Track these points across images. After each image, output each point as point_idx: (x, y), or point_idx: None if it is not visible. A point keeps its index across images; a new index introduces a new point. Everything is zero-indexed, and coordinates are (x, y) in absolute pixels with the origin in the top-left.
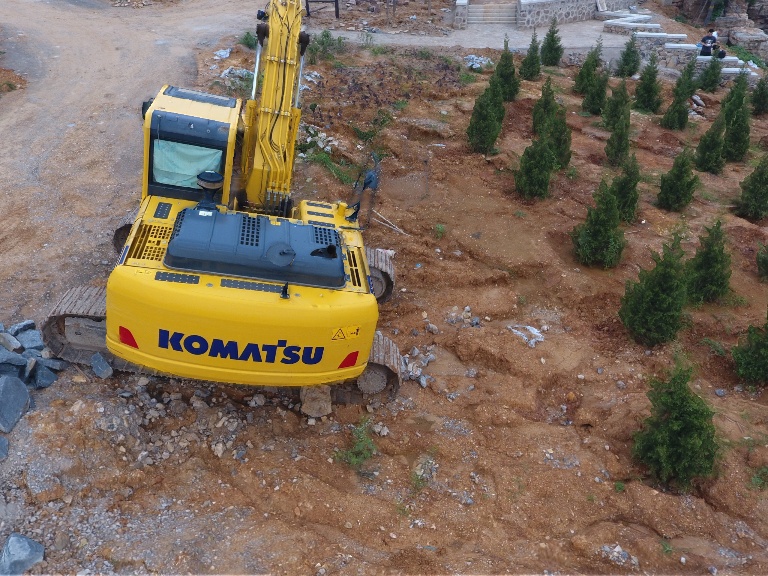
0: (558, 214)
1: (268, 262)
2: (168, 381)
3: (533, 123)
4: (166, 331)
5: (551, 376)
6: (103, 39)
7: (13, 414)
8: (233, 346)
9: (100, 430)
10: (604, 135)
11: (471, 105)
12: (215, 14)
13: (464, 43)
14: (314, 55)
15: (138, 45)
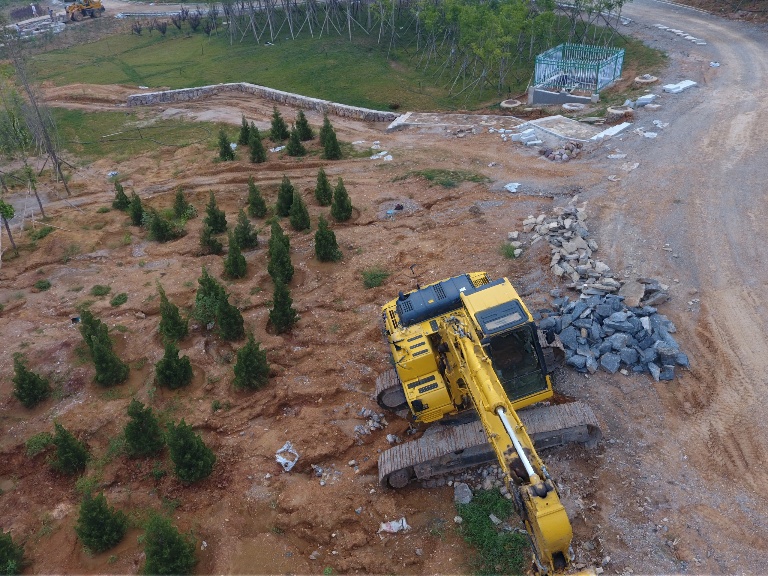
0: None
1: None
2: None
3: None
4: None
5: None
6: None
7: None
8: None
9: None
10: None
11: None
12: None
13: None
14: None
15: None
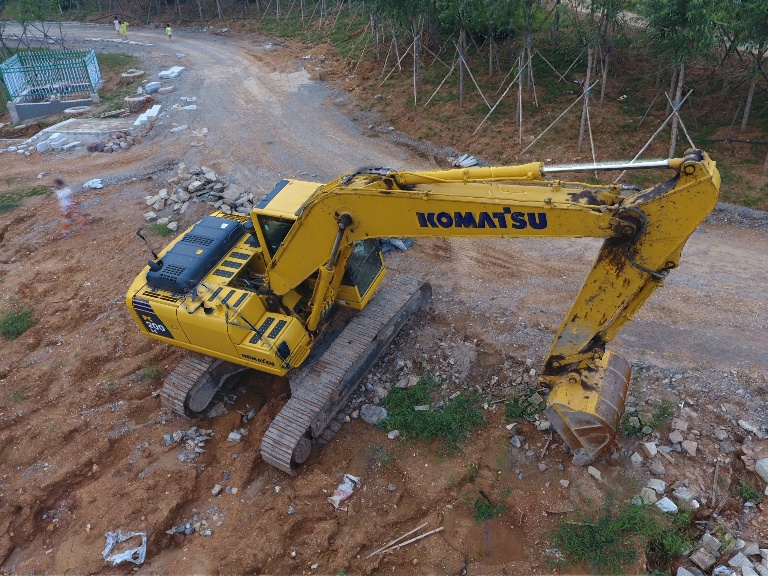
0: None
1: None
2: None
3: None
4: None
5: None
6: None
7: None
8: None
9: None
10: None
11: None
12: None
13: None
14: None
15: None
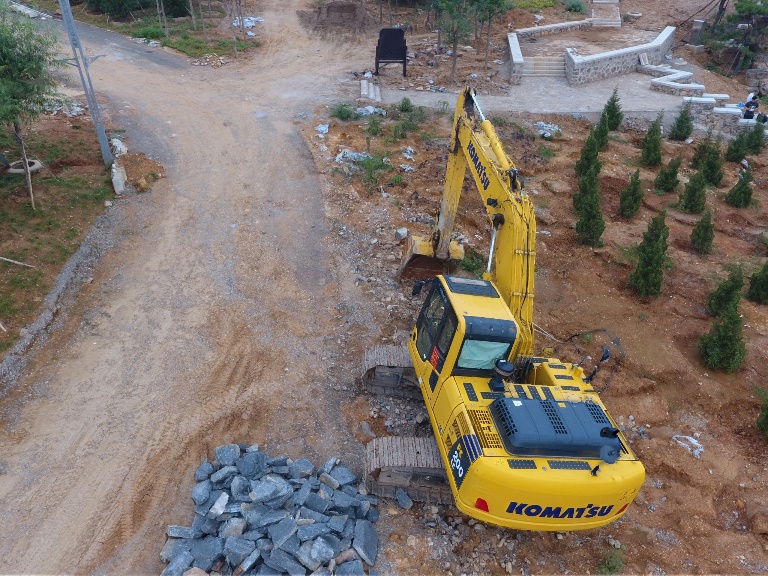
0: (674, 314)
1: (575, 445)
2: (447, 506)
3: (621, 207)
4: (515, 503)
5: (722, 487)
6: (206, 111)
7: (374, 551)
8: (558, 510)
9: (433, 559)
10: (683, 218)
11: (560, 186)
12: (293, 75)
13: (527, 105)
14: (405, 129)
15: (242, 119)
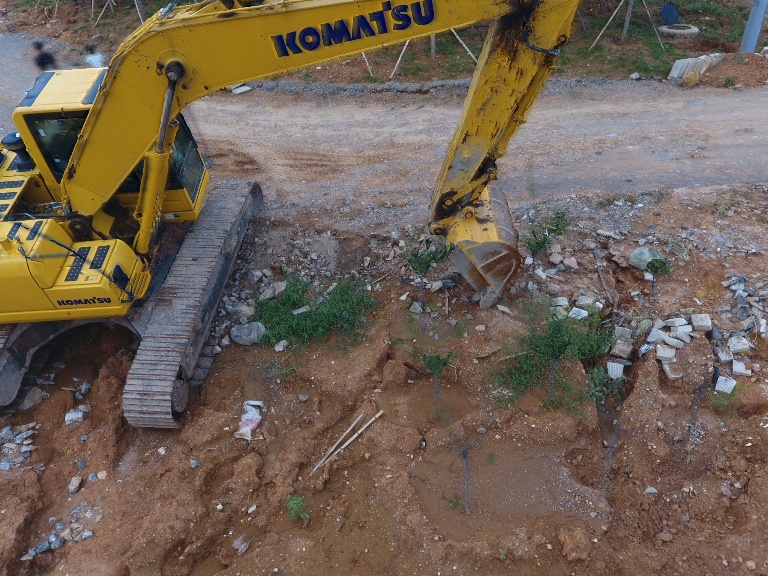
0: None
1: None
2: None
3: None
4: None
5: None
6: None
7: None
8: None
9: None
10: None
11: None
12: None
13: None
14: None
15: None
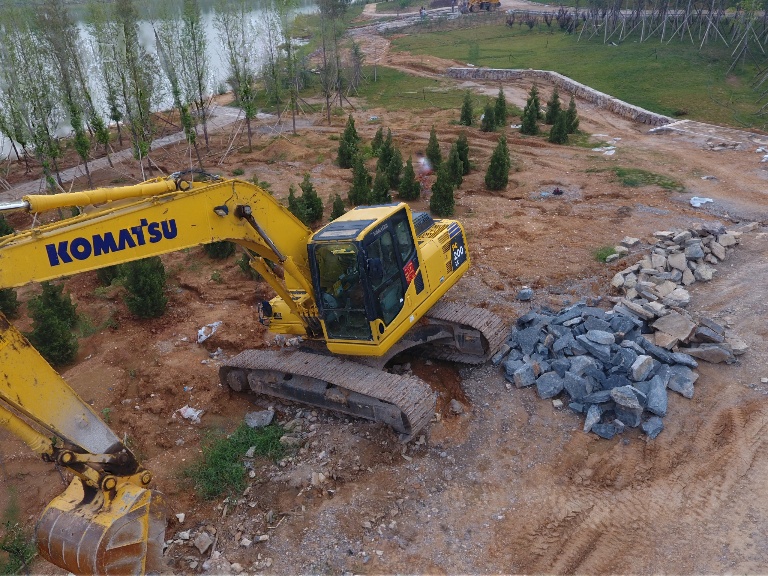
0: None
1: None
2: None
3: None
4: None
5: None
6: None
7: None
8: None
9: None
10: None
11: None
12: None
13: None
14: None
15: None
